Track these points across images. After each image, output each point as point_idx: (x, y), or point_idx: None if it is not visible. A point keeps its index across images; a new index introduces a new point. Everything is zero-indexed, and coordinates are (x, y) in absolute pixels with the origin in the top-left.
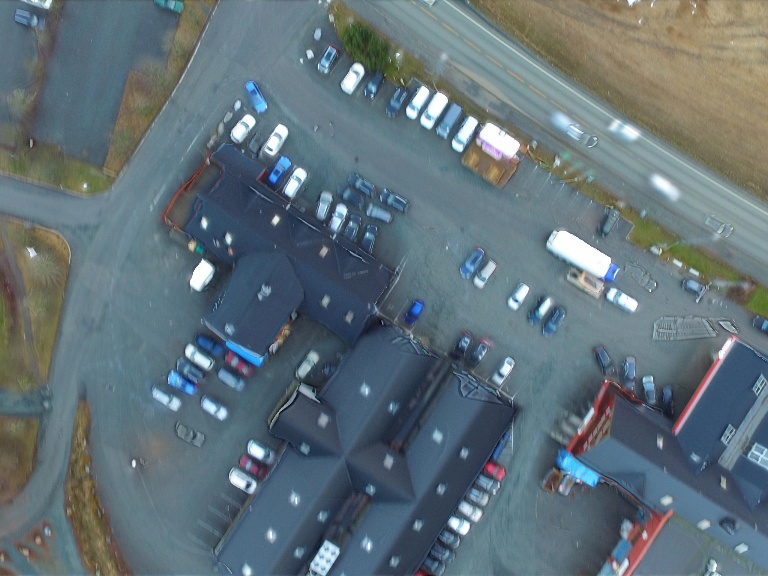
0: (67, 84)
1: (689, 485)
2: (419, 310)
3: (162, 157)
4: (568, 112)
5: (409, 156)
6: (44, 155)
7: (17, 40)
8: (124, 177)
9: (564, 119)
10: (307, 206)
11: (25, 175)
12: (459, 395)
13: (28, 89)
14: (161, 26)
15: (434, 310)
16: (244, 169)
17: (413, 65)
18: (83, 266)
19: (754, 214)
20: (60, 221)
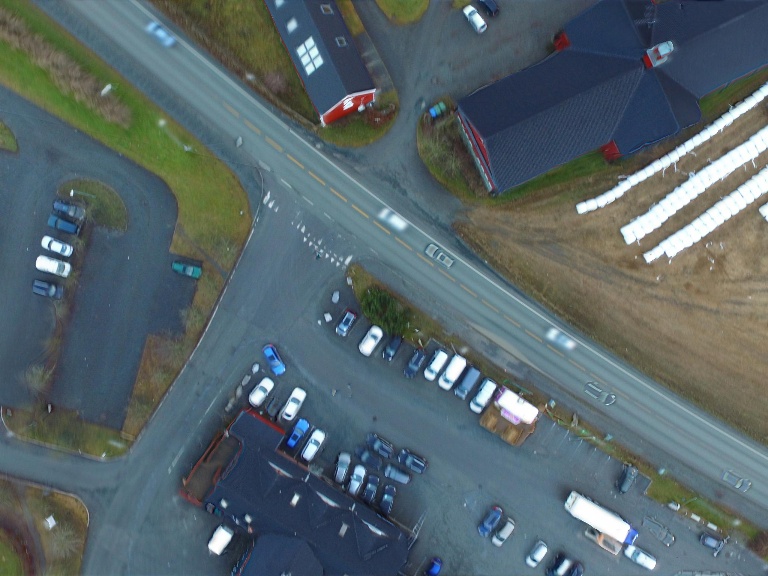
0: (85, 350)
1: None
2: (437, 571)
3: (180, 420)
4: (586, 370)
5: (427, 415)
6: (62, 420)
7: (35, 307)
8: (142, 440)
9: (582, 377)
10: (325, 466)
11: (43, 440)
12: None
13: (47, 363)
14: (179, 290)
15: (452, 567)
16: (263, 440)
17: (431, 326)
18: (101, 528)
19: None
20: (78, 485)
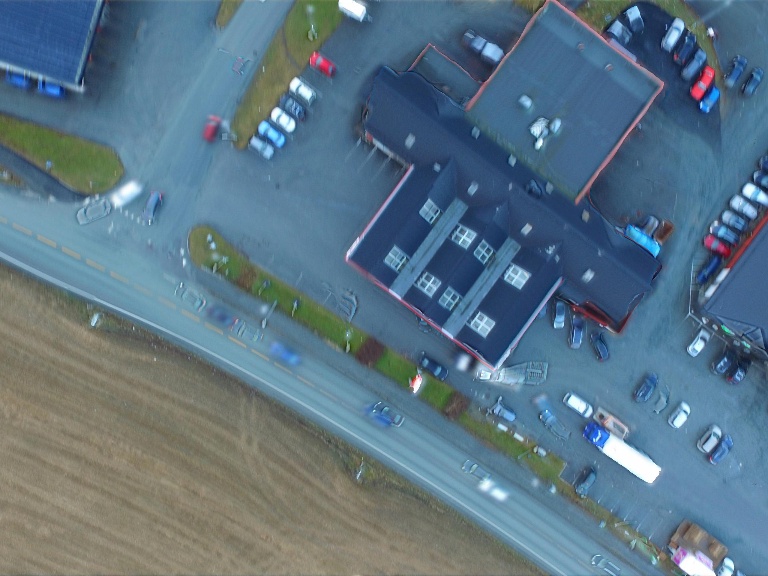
0: None
1: (577, 235)
2: None
3: None
4: None
5: None
6: None
7: None
8: None
9: None
10: None
11: None
12: (765, 330)
13: None
14: None
15: (759, 406)
16: None
17: None
18: None
19: (441, 481)
20: None
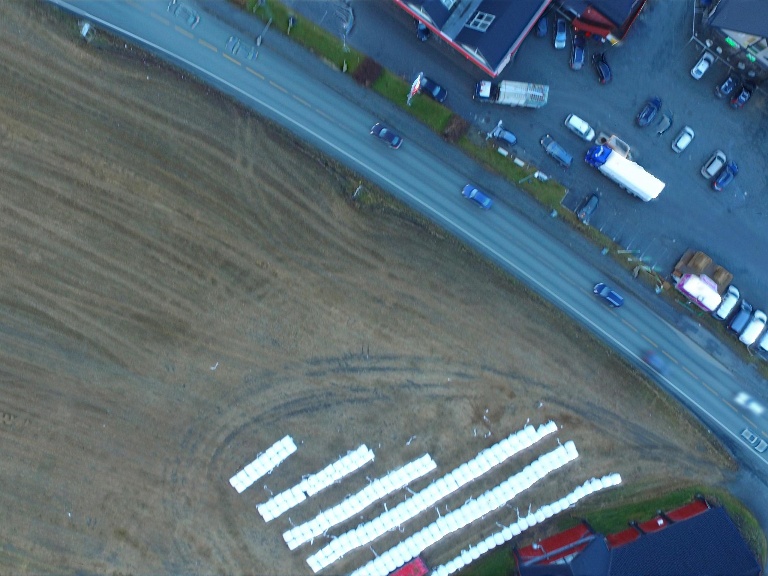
0: None
1: None
2: None
3: None
4: (621, 319)
5: None
6: None
7: None
8: None
9: (626, 313)
10: None
11: None
12: None
13: None
14: None
15: (764, 133)
16: None
17: None
18: None
19: (440, 206)
20: None
